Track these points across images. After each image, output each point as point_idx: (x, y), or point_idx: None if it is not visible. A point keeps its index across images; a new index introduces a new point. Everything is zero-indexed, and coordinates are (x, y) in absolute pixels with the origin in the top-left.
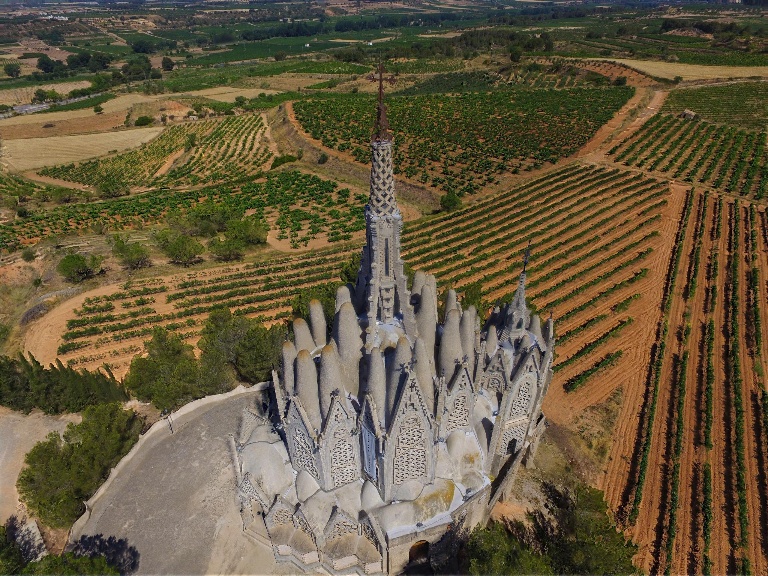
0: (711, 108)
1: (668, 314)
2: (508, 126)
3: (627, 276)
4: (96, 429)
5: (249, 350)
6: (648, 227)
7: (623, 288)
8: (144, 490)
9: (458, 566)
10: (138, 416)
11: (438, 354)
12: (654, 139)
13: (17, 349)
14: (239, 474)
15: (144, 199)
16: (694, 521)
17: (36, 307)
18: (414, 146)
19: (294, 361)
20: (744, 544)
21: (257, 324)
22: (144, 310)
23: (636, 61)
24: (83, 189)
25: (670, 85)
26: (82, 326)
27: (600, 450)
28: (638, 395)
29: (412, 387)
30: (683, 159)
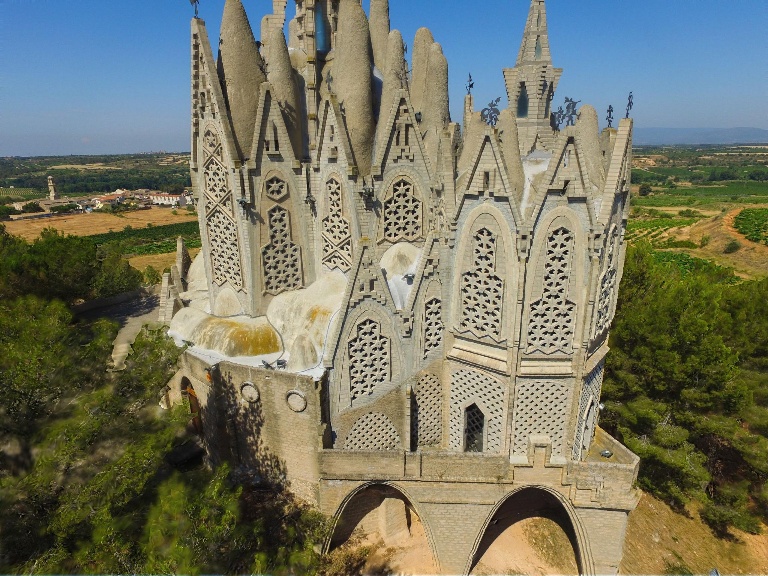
0: None
1: None
2: None
3: None
4: None
5: None
6: None
7: None
8: None
9: None
10: None
11: None
12: None
13: None
14: None
15: None
16: None
17: None
18: None
19: None
20: None
21: None
22: None
23: None
24: None
25: None
26: None
27: None
28: None
29: None
30: None
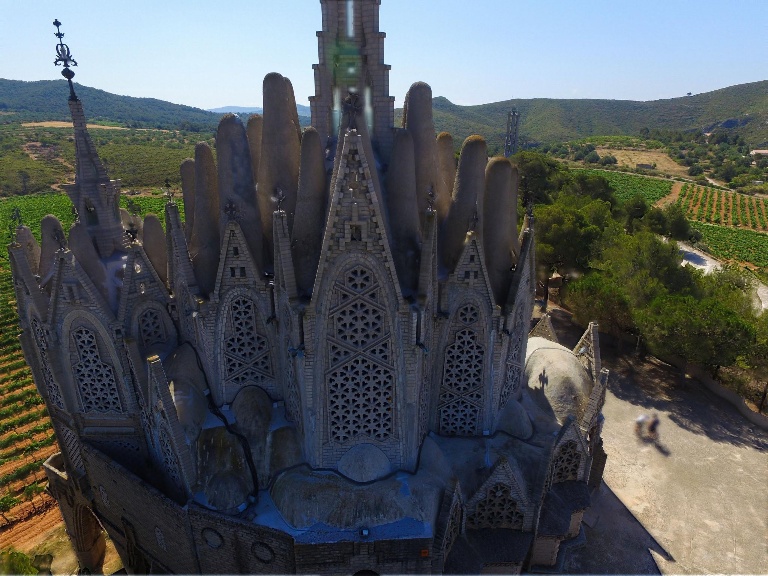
0: None
1: None
2: None
3: None
4: None
5: None
6: None
7: None
8: (767, 495)
9: None
10: None
11: None
12: None
13: None
14: None
15: None
16: None
17: None
18: None
19: None
20: None
21: None
22: None
23: None
24: None
25: None
26: None
27: None
28: None
29: None
30: None
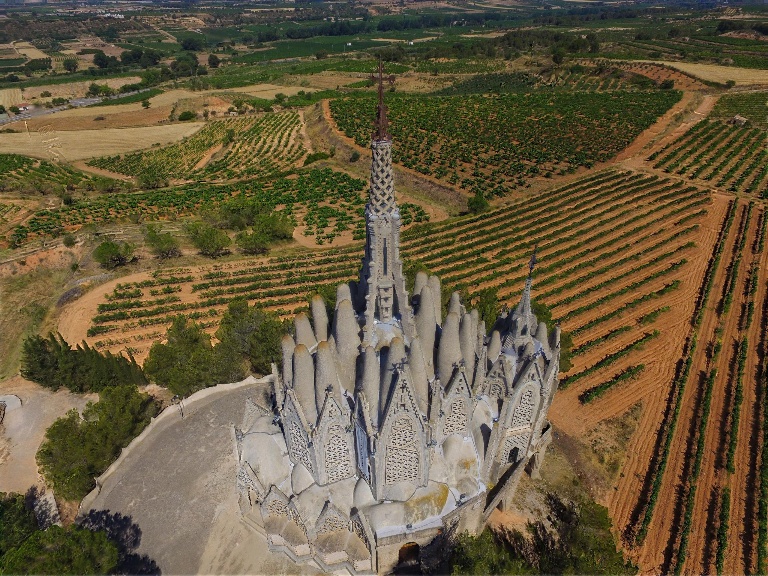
0: (765, 114)
1: (698, 329)
2: (544, 129)
3: (657, 287)
4: (111, 409)
5: (262, 342)
6: (684, 237)
7: (652, 300)
8: (151, 471)
9: (449, 571)
10: (155, 400)
11: (437, 356)
12: (699, 146)
13: (51, 329)
14: (238, 462)
15: (180, 191)
16: (707, 547)
17: (71, 290)
18: (446, 147)
19: (293, 355)
20: (760, 575)
21: (273, 317)
22: (170, 298)
23: (685, 64)
24: (125, 180)
25: (721, 89)
26: (112, 311)
27: (612, 466)
28: (658, 411)
29: (403, 388)
30: (729, 167)
